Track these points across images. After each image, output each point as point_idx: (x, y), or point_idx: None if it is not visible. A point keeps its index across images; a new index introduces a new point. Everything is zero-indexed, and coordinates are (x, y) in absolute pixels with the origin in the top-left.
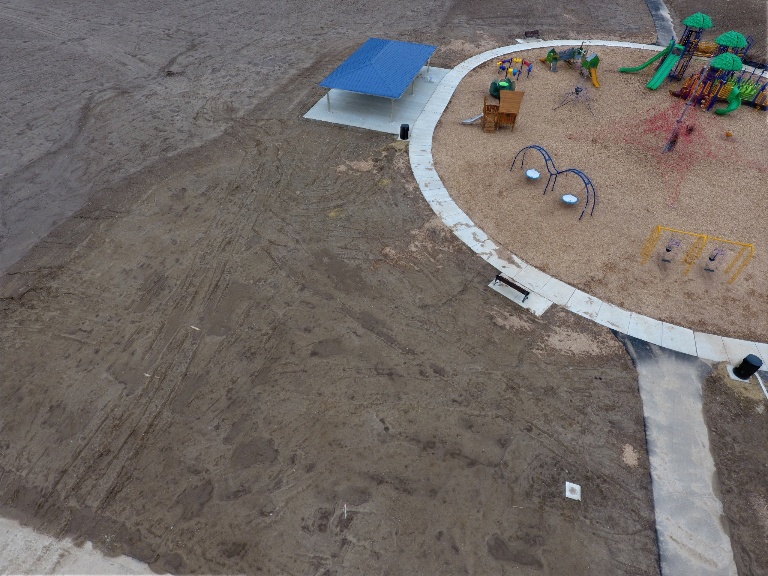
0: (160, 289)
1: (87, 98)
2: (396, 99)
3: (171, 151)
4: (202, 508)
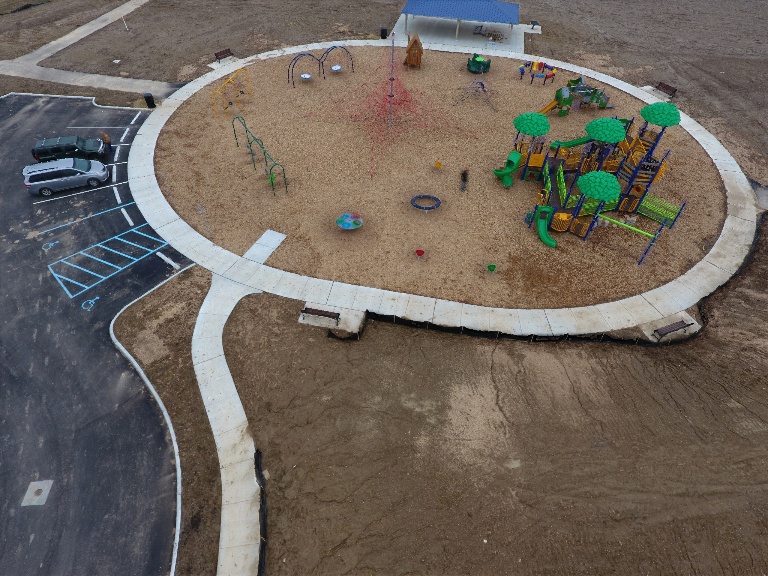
0: (239, 1)
1: None
2: None
3: None
4: None
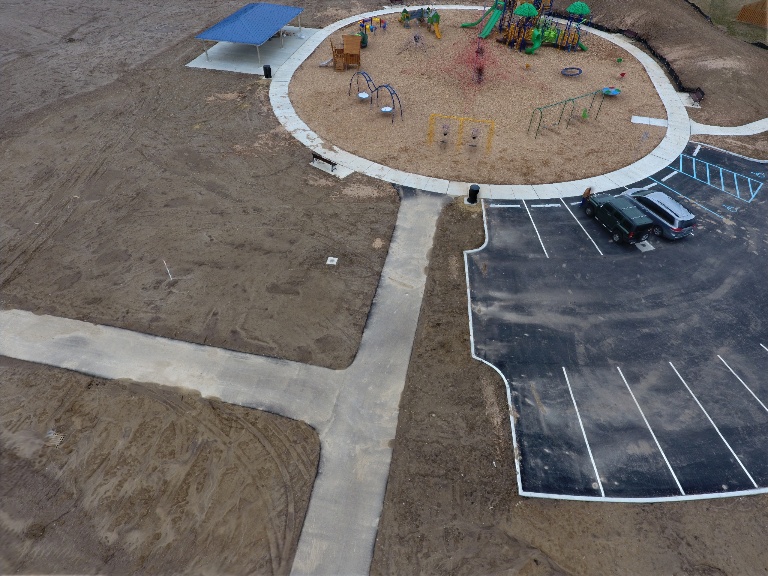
0: (50, 176)
1: None
2: (267, 50)
3: (68, 95)
4: (72, 284)
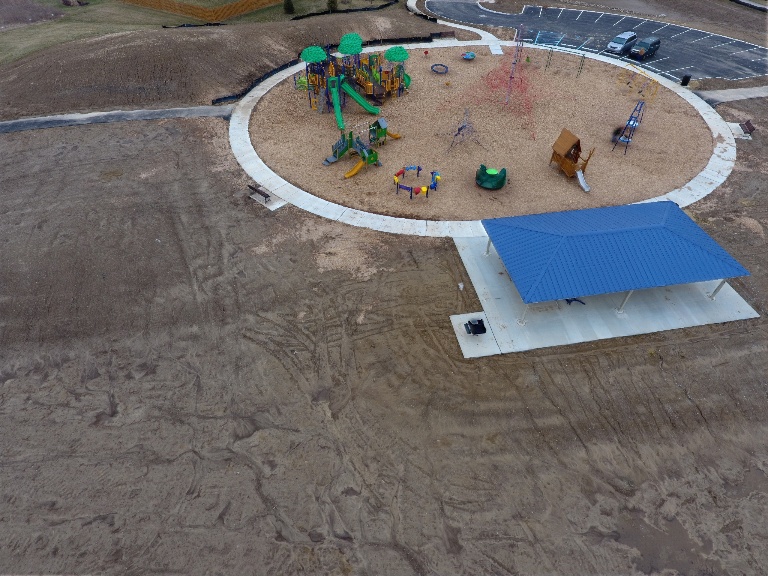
0: None
1: None
2: None
3: None
4: None
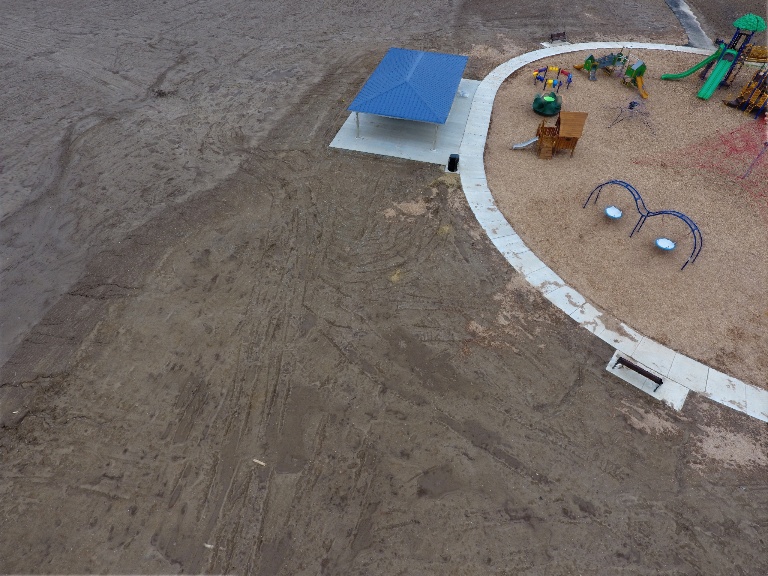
0: (202, 403)
1: (66, 128)
2: None
3: (179, 196)
4: None
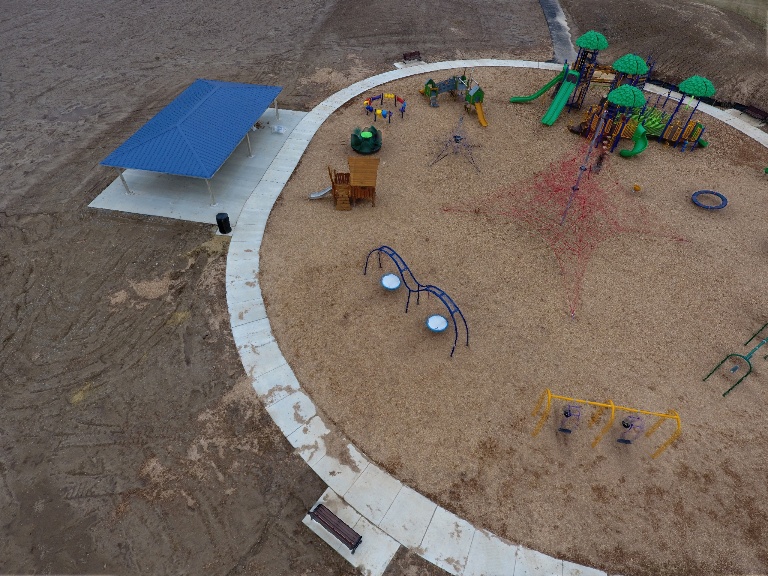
0: None
1: None
2: None
3: None
4: None
